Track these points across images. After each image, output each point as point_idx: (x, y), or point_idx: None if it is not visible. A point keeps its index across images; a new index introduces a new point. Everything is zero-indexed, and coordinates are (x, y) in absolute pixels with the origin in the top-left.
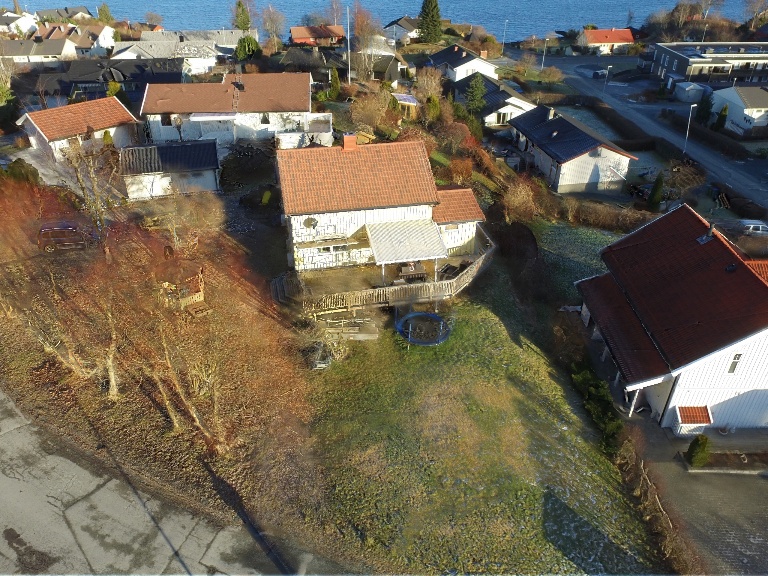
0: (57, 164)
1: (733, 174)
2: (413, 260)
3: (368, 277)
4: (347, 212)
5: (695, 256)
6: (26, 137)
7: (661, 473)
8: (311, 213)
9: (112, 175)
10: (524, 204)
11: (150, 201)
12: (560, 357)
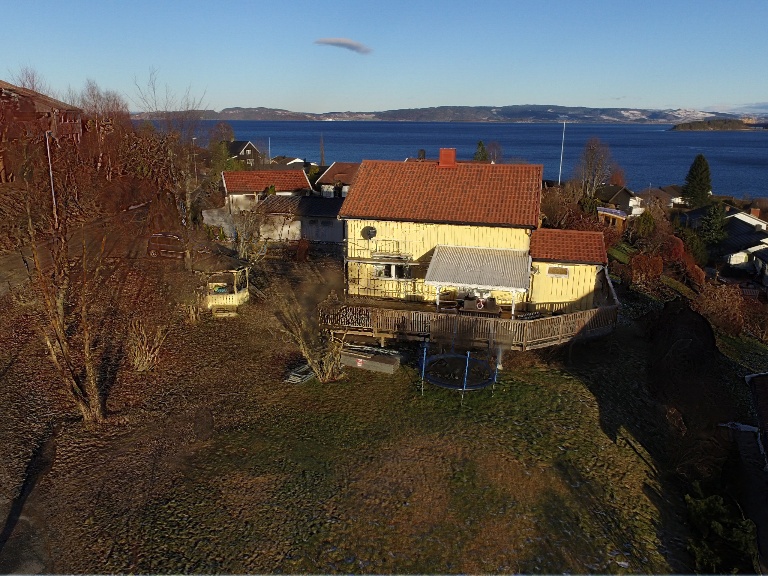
0: (230, 216)
1: None
2: (476, 287)
3: None
4: (414, 225)
5: None
6: (223, 197)
7: None
8: (368, 218)
9: None
10: (725, 311)
11: (276, 242)
12: (677, 468)
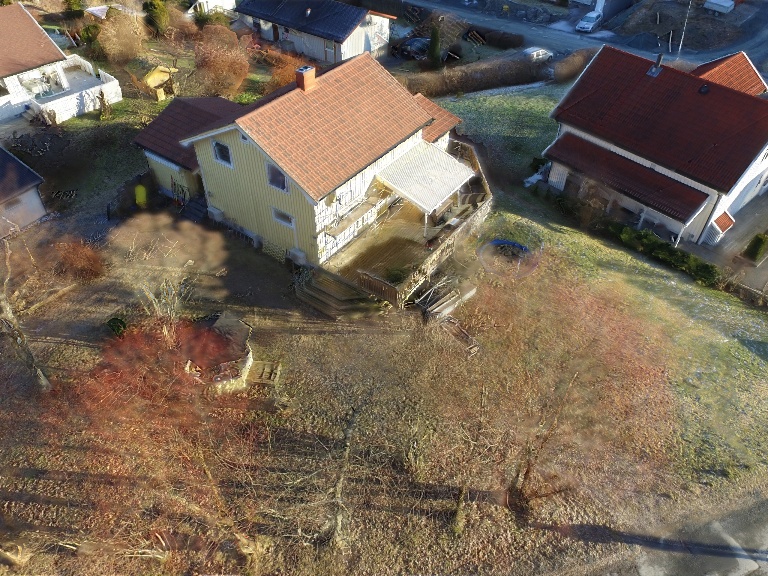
0: None
1: (451, 12)
2: (452, 193)
3: (397, 234)
4: None
5: (659, 89)
6: None
7: (748, 279)
8: (337, 186)
9: (7, 256)
10: None
11: None
12: (596, 226)
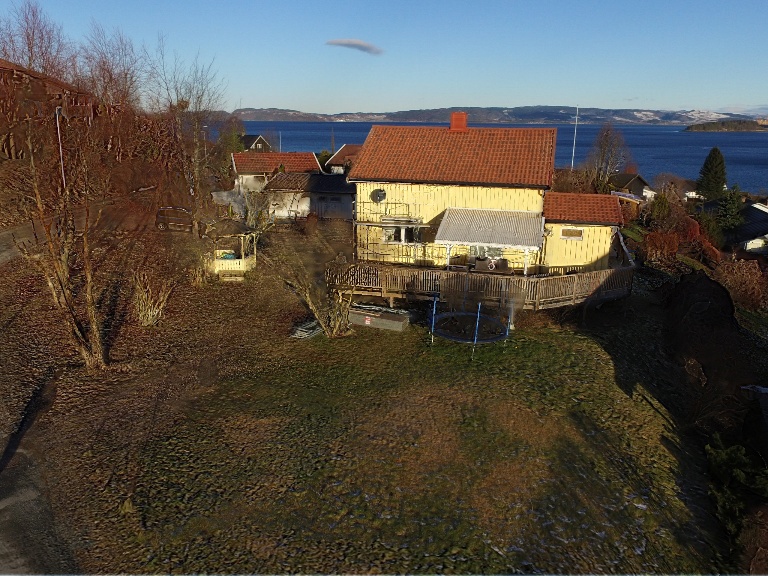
0: (240, 196)
1: None
2: (488, 246)
3: None
4: (425, 187)
5: None
6: (233, 180)
7: None
8: (378, 180)
9: None
10: (743, 285)
11: (285, 219)
12: (696, 421)
